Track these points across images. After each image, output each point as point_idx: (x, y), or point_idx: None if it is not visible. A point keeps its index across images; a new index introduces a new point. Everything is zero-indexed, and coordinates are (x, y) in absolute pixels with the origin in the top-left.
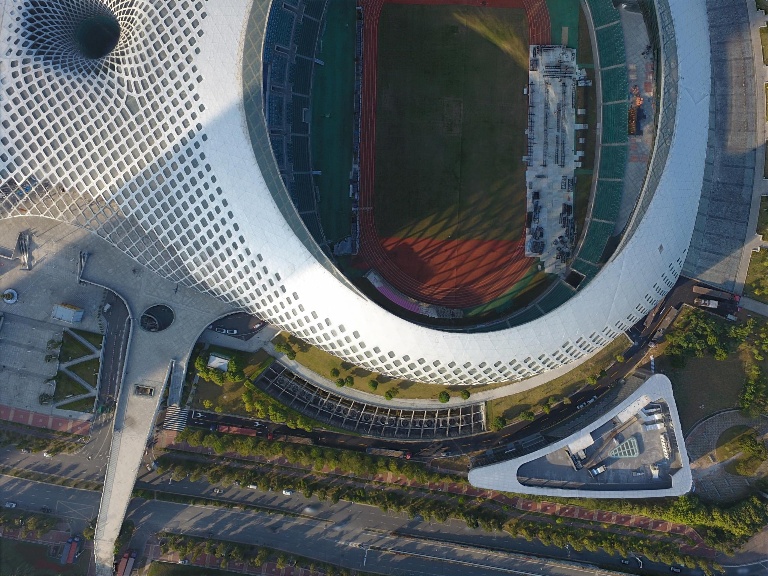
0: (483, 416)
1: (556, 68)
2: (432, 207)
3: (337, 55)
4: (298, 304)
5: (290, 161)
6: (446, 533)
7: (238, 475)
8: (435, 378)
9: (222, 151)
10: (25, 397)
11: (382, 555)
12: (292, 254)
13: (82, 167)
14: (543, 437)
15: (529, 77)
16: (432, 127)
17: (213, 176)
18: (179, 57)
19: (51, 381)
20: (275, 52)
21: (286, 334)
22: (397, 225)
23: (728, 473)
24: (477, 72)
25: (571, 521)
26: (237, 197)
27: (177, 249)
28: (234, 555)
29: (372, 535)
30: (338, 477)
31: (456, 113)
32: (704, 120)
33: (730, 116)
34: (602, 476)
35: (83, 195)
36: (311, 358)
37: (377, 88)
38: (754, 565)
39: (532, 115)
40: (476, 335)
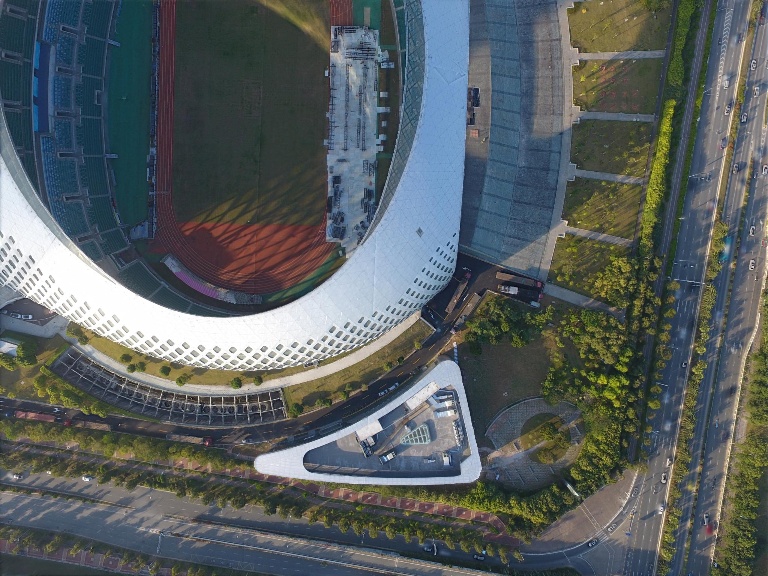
0: (283, 403)
1: (357, 50)
2: (231, 191)
3: (134, 36)
4: (57, 287)
5: (80, 144)
6: (247, 520)
7: (37, 461)
8: (208, 363)
9: None
10: None
11: (183, 542)
12: (39, 236)
13: None
14: (340, 424)
15: (330, 59)
16: (231, 110)
17: None
18: None
19: None
20: (61, 32)
21: None
22: (195, 209)
23: (533, 461)
24: (277, 54)
25: (373, 508)
26: None
27: None
28: (26, 541)
29: (172, 522)
30: (138, 463)
31: (256, 96)
32: (461, 100)
33: (536, 99)
34: (394, 463)
35: None
36: (106, 344)
37: (175, 70)
38: (558, 553)
39: (333, 98)
40: (230, 319)
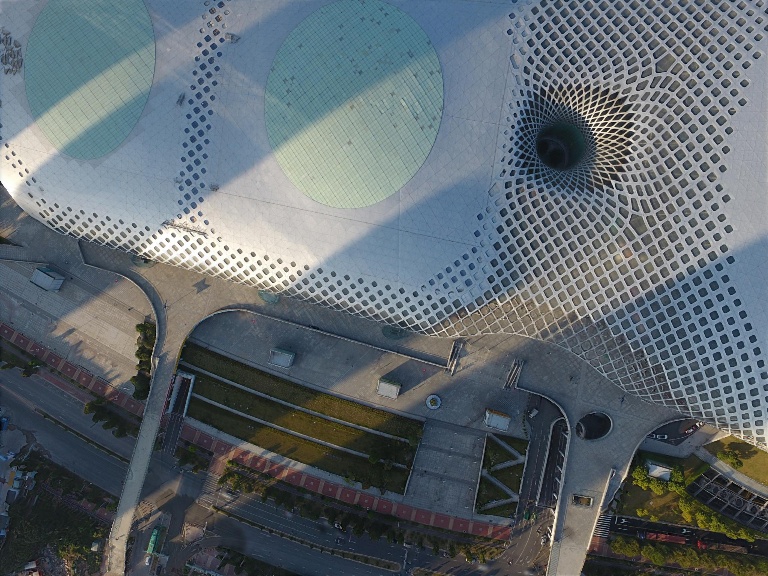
0: None
1: None
2: None
3: None
4: None
5: None
6: None
7: None
8: None
9: (754, 275)
10: (445, 502)
11: None
12: None
13: (573, 287)
14: None
15: None
16: None
17: (737, 299)
18: (698, 175)
19: (471, 486)
20: None
21: (726, 441)
22: None
23: None
24: None
25: None
26: (767, 322)
27: (665, 368)
28: None
29: None
30: None
31: None
32: None
33: None
34: None
35: (567, 314)
36: (752, 465)
37: None
38: None
39: None
40: None
